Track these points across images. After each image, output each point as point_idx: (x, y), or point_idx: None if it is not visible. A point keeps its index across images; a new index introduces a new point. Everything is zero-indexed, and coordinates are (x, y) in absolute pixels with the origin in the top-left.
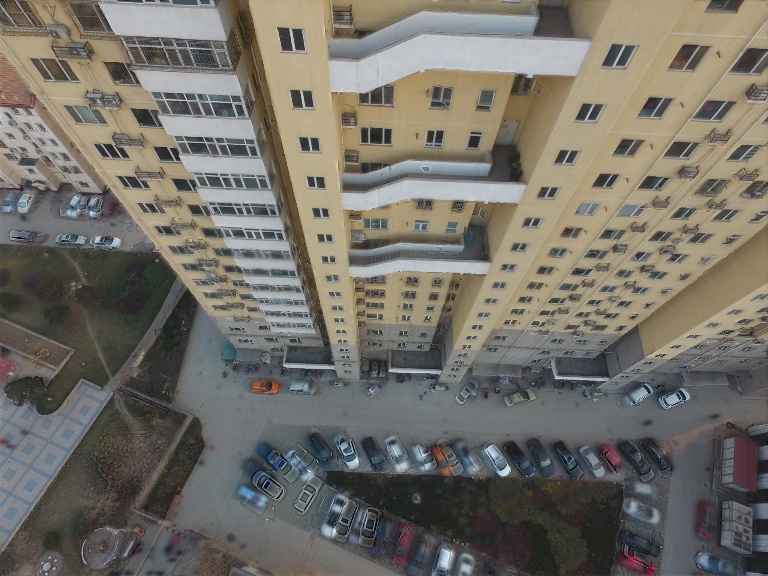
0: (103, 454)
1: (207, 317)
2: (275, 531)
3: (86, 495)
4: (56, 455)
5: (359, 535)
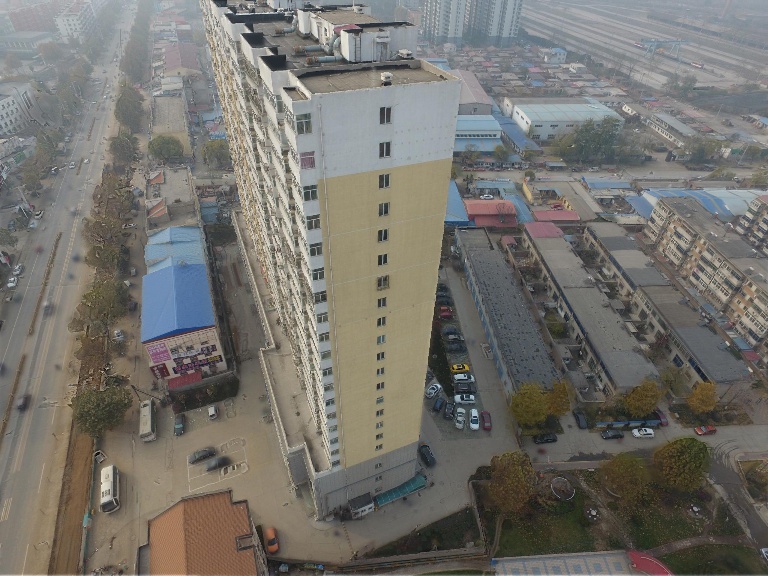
0: (525, 473)
1: (399, 527)
2: (490, 408)
3: (552, 521)
4: (552, 568)
5: (466, 372)
